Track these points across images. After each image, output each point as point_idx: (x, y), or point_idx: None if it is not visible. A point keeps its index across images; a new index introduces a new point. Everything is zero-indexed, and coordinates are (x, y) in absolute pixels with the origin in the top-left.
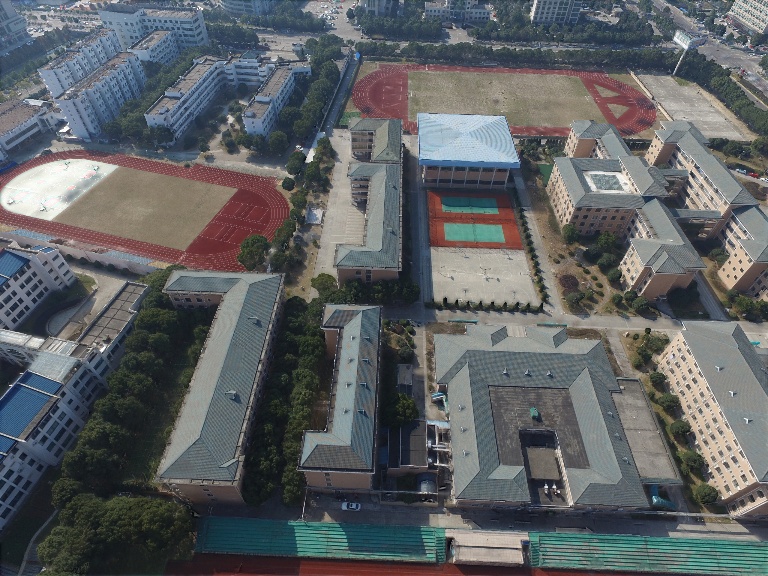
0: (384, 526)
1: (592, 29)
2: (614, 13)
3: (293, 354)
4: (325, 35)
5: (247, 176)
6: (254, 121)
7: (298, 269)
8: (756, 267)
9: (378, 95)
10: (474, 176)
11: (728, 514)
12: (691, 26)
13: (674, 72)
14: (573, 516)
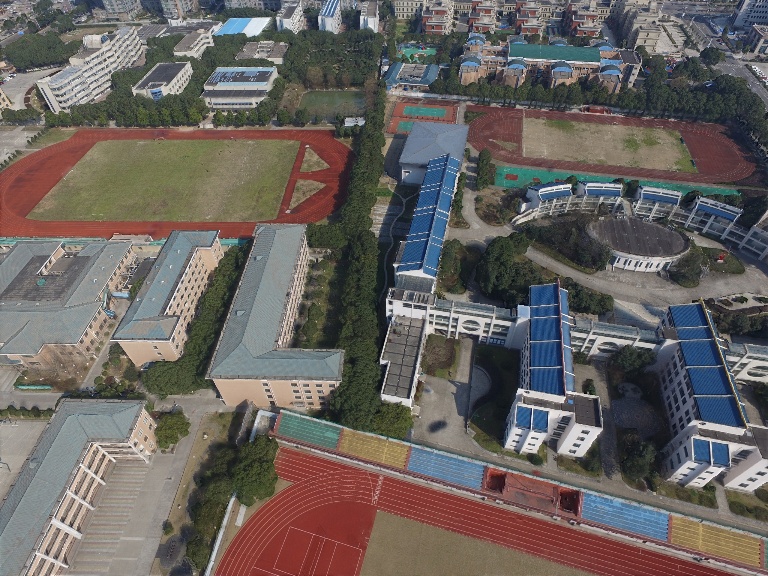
0: None
1: None
2: None
3: (219, 320)
4: None
5: None
6: None
7: None
8: None
9: None
10: None
11: None
12: None
13: None
14: None
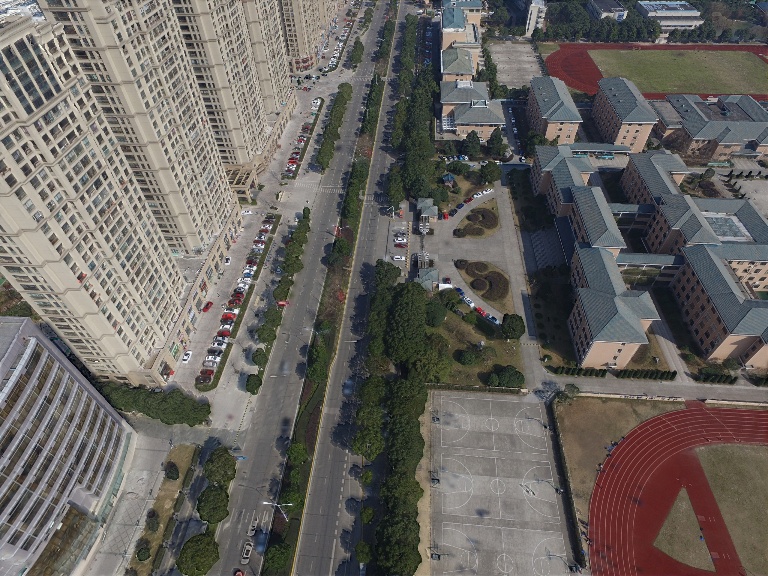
0: None
1: None
2: None
3: None
4: None
5: None
6: None
7: None
8: None
9: None
10: None
11: None
12: None
13: None
14: None
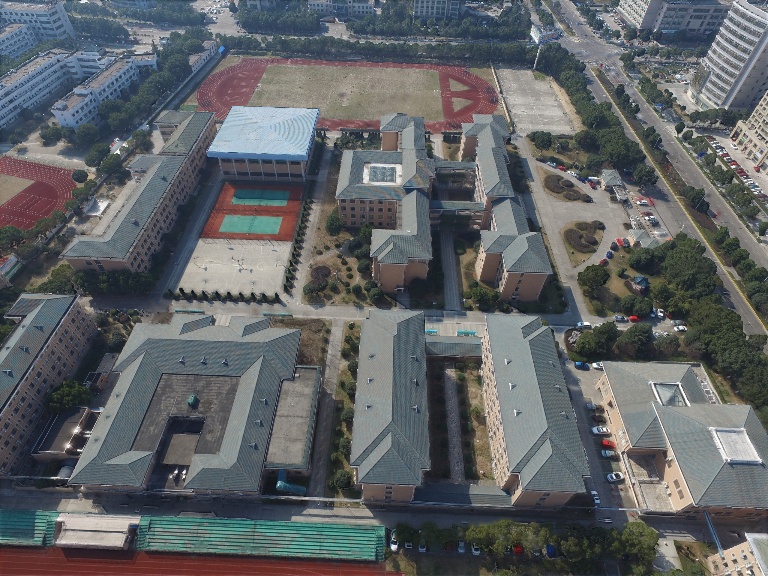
0: (0, 510)
1: (465, 23)
2: (504, 8)
3: None
4: (190, 29)
5: (51, 168)
6: (63, 113)
7: (54, 260)
8: (491, 258)
9: (225, 88)
10: (270, 168)
11: (360, 499)
12: (578, 21)
13: (534, 66)
14: (204, 501)
